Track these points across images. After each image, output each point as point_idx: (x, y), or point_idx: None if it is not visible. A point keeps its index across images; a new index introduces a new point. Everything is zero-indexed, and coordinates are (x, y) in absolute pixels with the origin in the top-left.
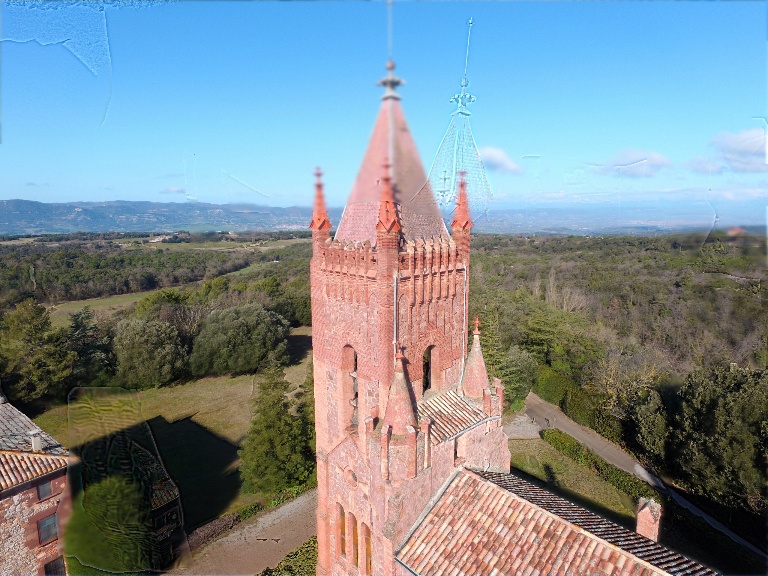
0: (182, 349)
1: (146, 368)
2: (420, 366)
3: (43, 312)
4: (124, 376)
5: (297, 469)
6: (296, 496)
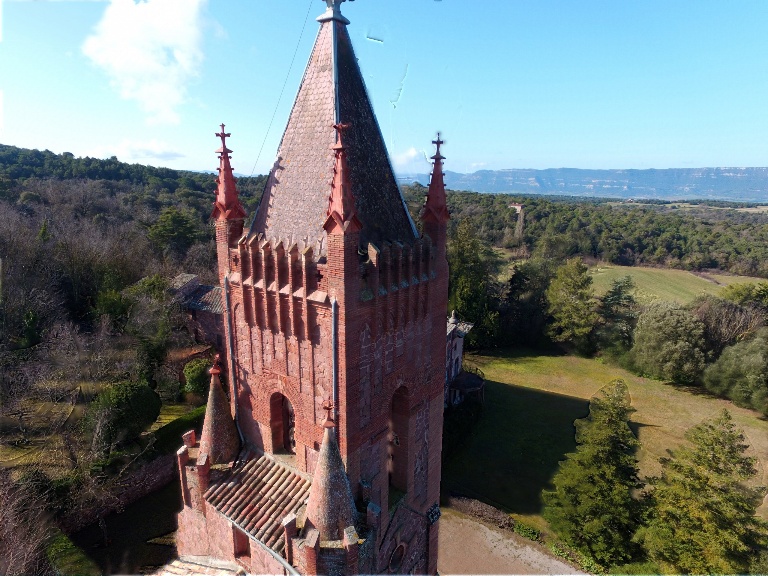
0: (699, 353)
1: (649, 356)
2: (267, 410)
3: (583, 271)
4: (635, 355)
5: (596, 540)
6: (587, 570)
